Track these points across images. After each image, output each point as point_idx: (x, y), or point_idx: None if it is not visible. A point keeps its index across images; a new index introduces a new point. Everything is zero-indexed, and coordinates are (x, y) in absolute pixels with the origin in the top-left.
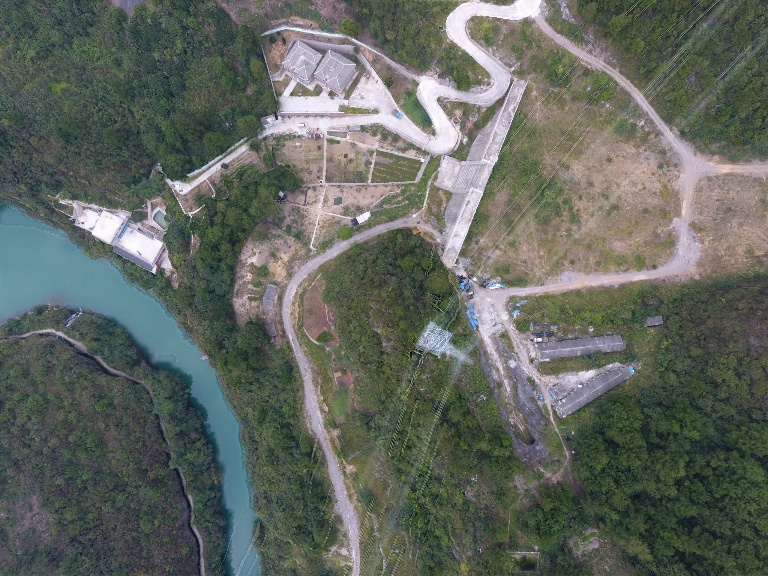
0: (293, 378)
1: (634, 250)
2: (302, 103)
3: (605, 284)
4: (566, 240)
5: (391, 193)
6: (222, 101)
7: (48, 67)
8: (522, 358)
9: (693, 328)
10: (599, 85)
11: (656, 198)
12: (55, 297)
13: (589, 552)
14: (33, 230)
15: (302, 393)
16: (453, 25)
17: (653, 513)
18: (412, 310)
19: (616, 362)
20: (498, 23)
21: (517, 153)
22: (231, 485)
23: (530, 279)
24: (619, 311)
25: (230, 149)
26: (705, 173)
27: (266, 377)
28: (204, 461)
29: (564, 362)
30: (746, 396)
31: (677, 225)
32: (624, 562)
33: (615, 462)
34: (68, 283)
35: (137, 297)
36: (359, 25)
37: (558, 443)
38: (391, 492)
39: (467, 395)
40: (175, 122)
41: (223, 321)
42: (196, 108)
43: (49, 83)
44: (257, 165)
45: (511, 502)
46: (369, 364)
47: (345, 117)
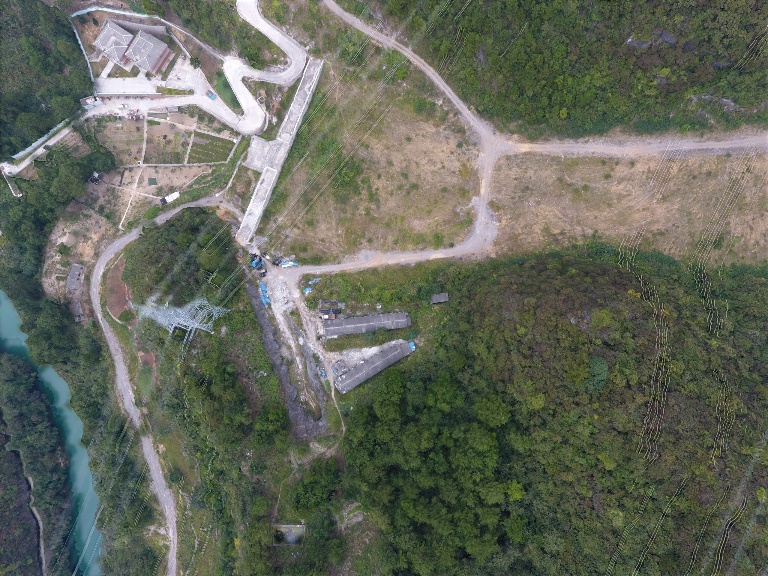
0: (101, 357)
1: (433, 229)
2: (120, 84)
3: (402, 262)
4: (365, 219)
5: (203, 173)
6: (37, 82)
7: None
8: (309, 335)
9: (467, 304)
10: (391, 64)
11: (455, 177)
12: None
13: (352, 525)
14: None
15: (112, 372)
16: (244, 4)
17: (400, 485)
18: (184, 286)
19: (400, 339)
20: (286, 1)
21: (317, 132)
22: (76, 468)
23: (327, 257)
24: None
25: (53, 131)
26: (504, 152)
27: (79, 357)
28: (46, 444)
29: (349, 339)
30: (493, 369)
31: (476, 204)
32: (377, 534)
33: (372, 435)
34: None
35: None
36: (165, 5)
37: (336, 419)
38: (198, 470)
39: (246, 371)
40: None
41: (21, 300)
42: (11, 89)
43: None
44: (82, 147)
45: (283, 476)
46: None
47: (164, 98)
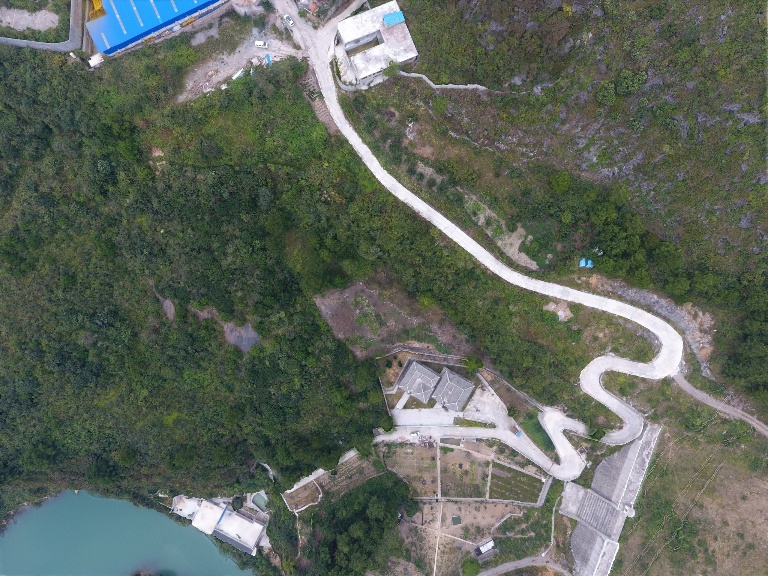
0: None
1: None
2: (415, 415)
3: None
4: None
5: (512, 515)
6: (335, 420)
7: (160, 403)
8: None
9: None
10: (737, 433)
11: None
12: (147, 567)
13: None
14: (125, 503)
15: None
16: (587, 378)
17: None
18: None
19: None
20: (635, 380)
21: (649, 493)
22: None
23: None
24: None
25: None
26: None
27: None
28: None
29: None
30: None
31: None
32: None
33: None
34: (161, 553)
35: (233, 568)
36: (480, 353)
37: None
38: None
39: None
40: (291, 452)
41: None
42: (309, 428)
43: (161, 418)
44: (366, 468)
45: None
46: None
47: (459, 427)
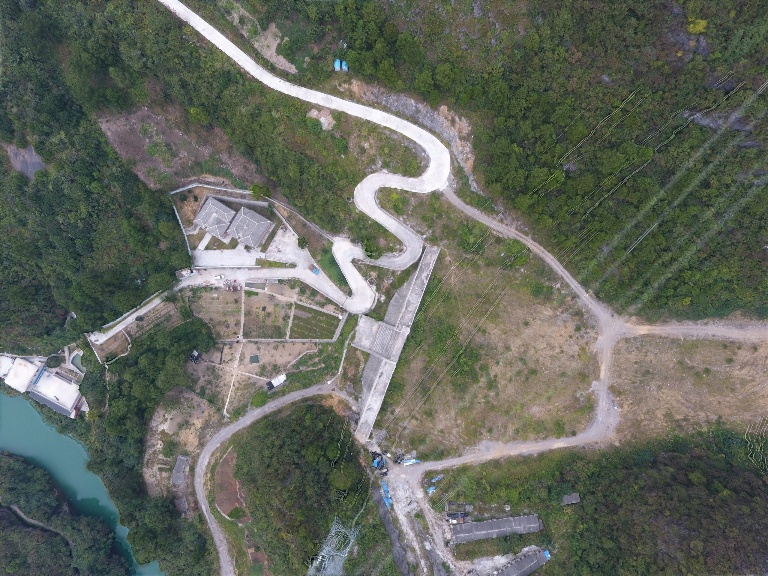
0: (206, 552)
1: (553, 415)
2: (217, 256)
3: (524, 453)
4: (484, 407)
5: (308, 352)
6: (133, 258)
7: None
8: (437, 540)
9: (607, 515)
10: (511, 253)
11: (574, 361)
12: None
13: None
14: None
15: (217, 565)
16: (361, 195)
17: None
18: (316, 507)
19: (532, 545)
20: (406, 195)
21: (432, 318)
22: None
23: (447, 450)
24: (536, 488)
25: (145, 301)
26: (623, 335)
27: (180, 547)
28: None
29: (480, 545)
30: None
31: (596, 389)
32: None
33: None
34: None
35: (58, 438)
36: (271, 185)
37: None
38: None
39: None
40: (82, 285)
41: (128, 502)
42: (106, 266)
43: None
44: (174, 316)
45: None
46: (277, 554)
47: (263, 269)
